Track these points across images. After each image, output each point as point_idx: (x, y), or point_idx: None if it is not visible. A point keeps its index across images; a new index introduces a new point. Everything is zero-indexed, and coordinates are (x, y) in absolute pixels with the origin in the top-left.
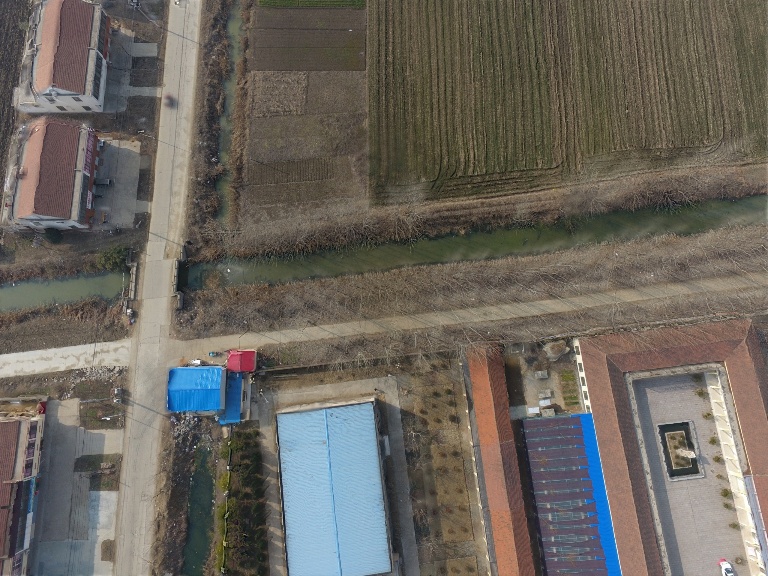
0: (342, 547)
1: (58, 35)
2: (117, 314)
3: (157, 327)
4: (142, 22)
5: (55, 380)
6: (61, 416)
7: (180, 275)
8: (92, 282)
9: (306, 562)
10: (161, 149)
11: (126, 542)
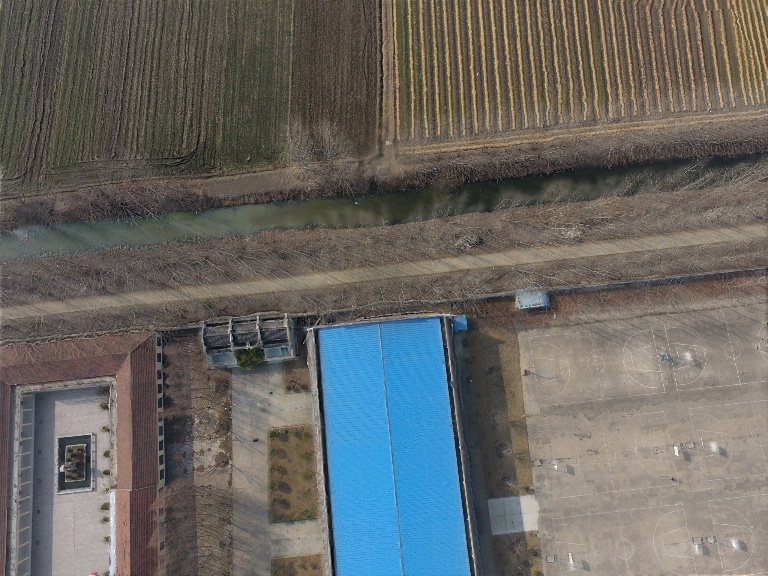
0: None
1: None
2: None
3: None
4: None
5: None
6: None
7: None
8: None
9: None
10: None
11: None
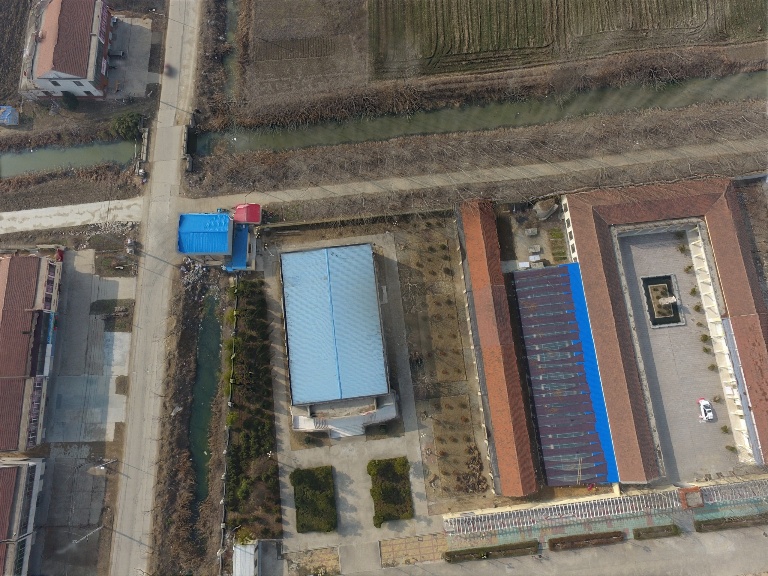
0: (342, 372)
1: None
2: (130, 176)
3: (168, 187)
4: None
5: (71, 234)
6: (77, 265)
7: (189, 140)
8: (106, 149)
9: (308, 386)
10: (171, 26)
11: (139, 378)
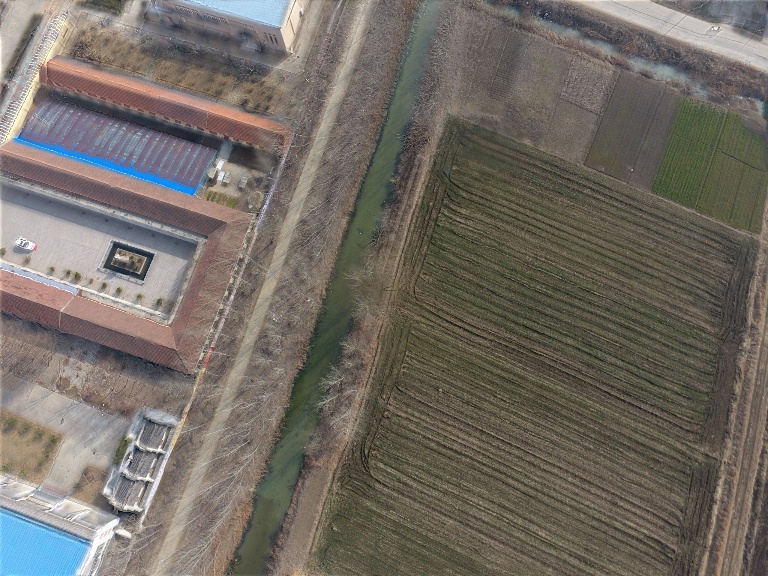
0: None
1: None
2: None
3: None
4: None
5: None
6: None
7: None
8: None
9: None
10: None
11: None
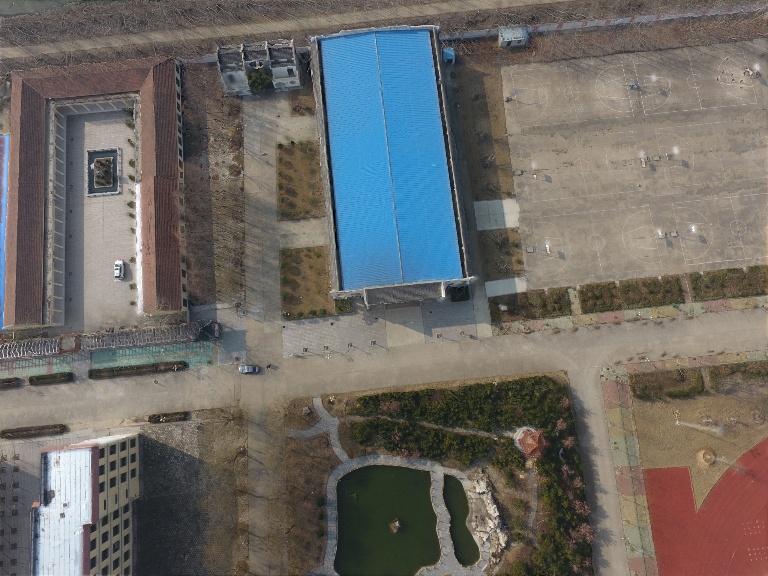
0: None
1: None
2: None
3: None
4: None
5: None
6: None
7: None
8: None
9: None
10: None
11: None
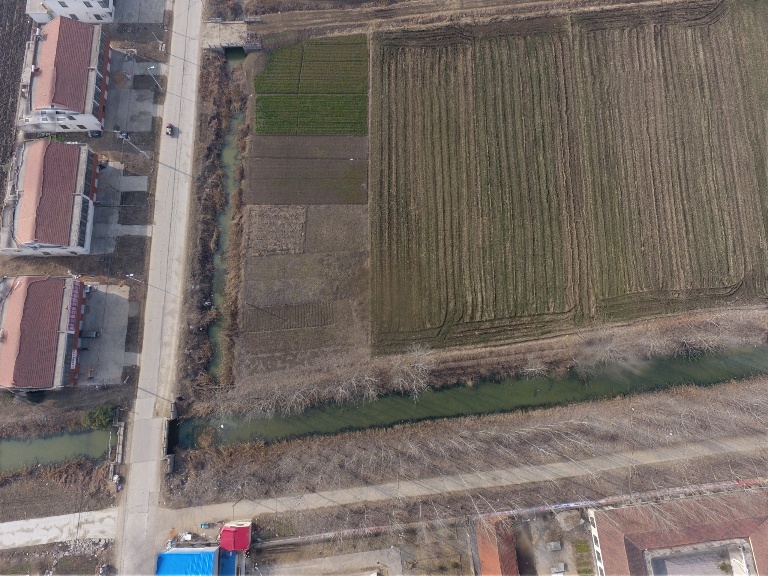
0: None
1: (41, 185)
2: (103, 479)
3: (146, 494)
4: (132, 153)
5: (36, 554)
6: None
7: (170, 435)
8: (77, 440)
9: None
10: (151, 294)
11: None
